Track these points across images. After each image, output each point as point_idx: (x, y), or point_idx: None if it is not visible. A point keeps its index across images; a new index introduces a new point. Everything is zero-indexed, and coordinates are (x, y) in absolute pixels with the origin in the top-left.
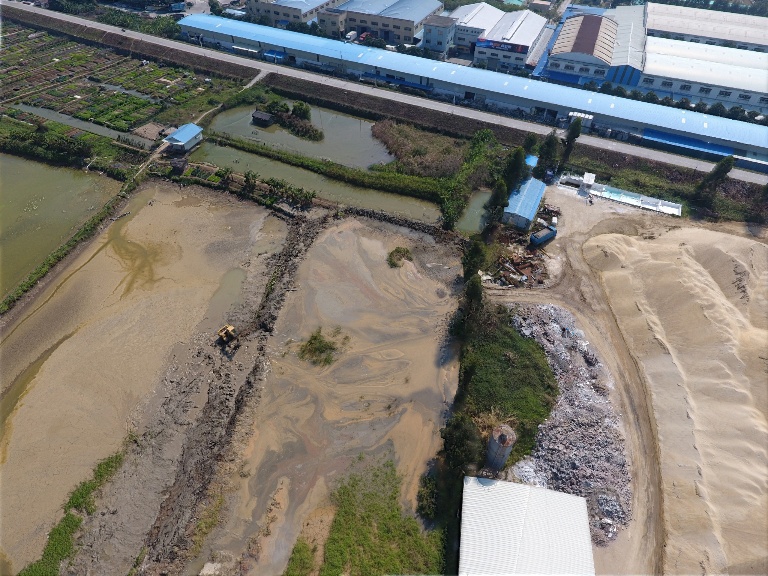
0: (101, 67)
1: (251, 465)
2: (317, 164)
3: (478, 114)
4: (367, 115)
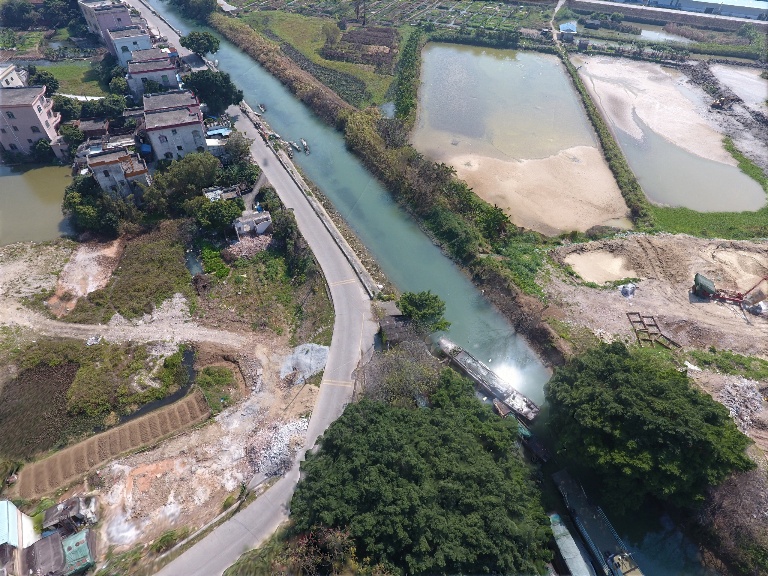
0: (435, 1)
1: None
2: (661, 43)
3: (730, 18)
4: (652, 22)
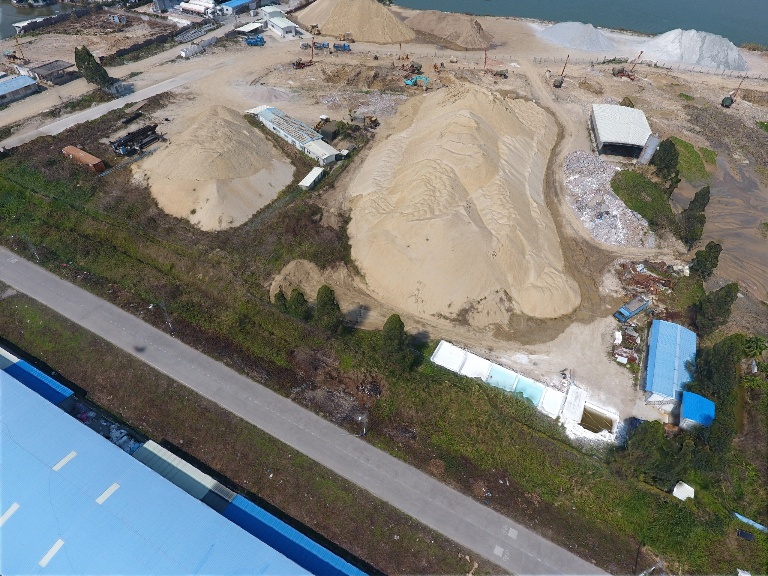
0: None
1: (762, 186)
2: None
3: None
4: None
